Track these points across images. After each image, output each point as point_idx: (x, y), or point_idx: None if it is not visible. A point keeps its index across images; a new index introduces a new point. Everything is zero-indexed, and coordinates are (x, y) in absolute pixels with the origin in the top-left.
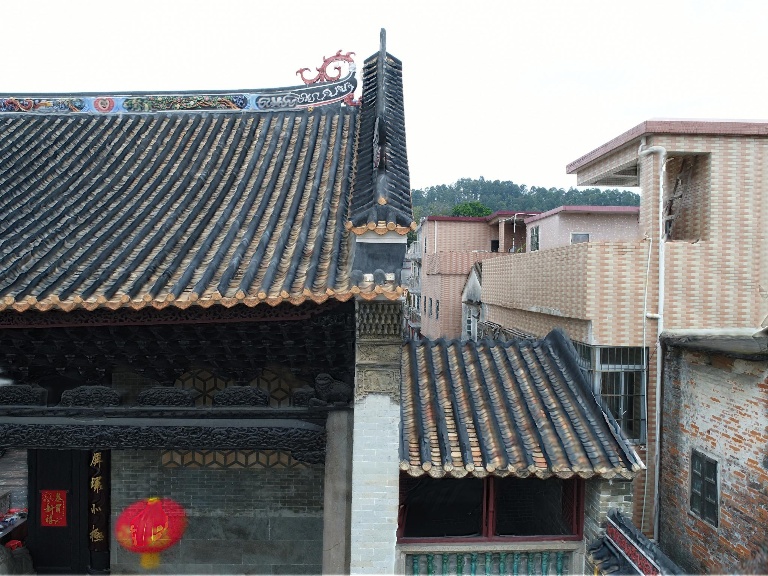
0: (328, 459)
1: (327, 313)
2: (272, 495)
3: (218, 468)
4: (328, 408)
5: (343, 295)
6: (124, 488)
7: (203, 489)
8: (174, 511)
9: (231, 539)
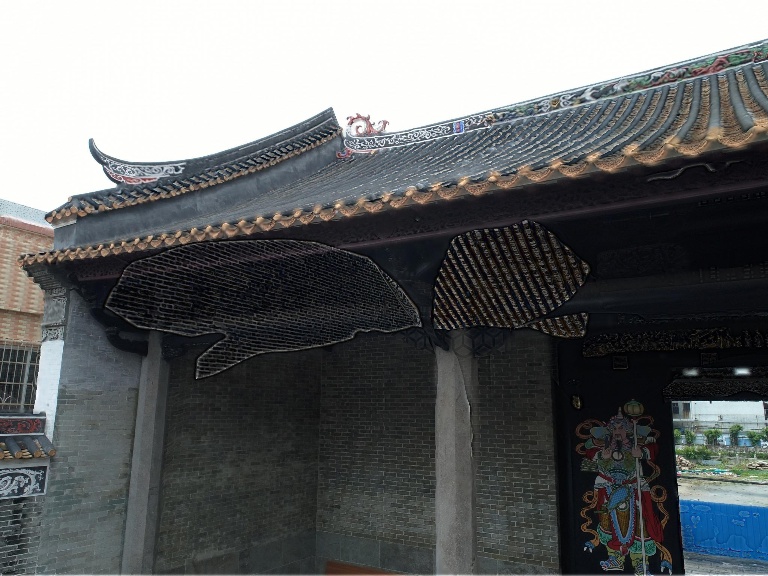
0: None
1: None
2: None
3: None
4: None
5: None
6: None
7: None
8: None
9: None
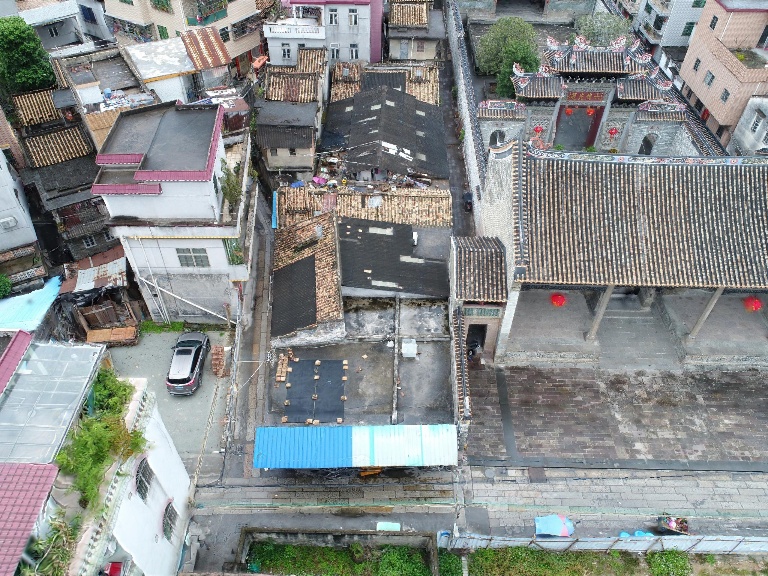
0: None
1: None
2: None
3: None
4: None
5: None
6: None
7: None
8: None
9: None
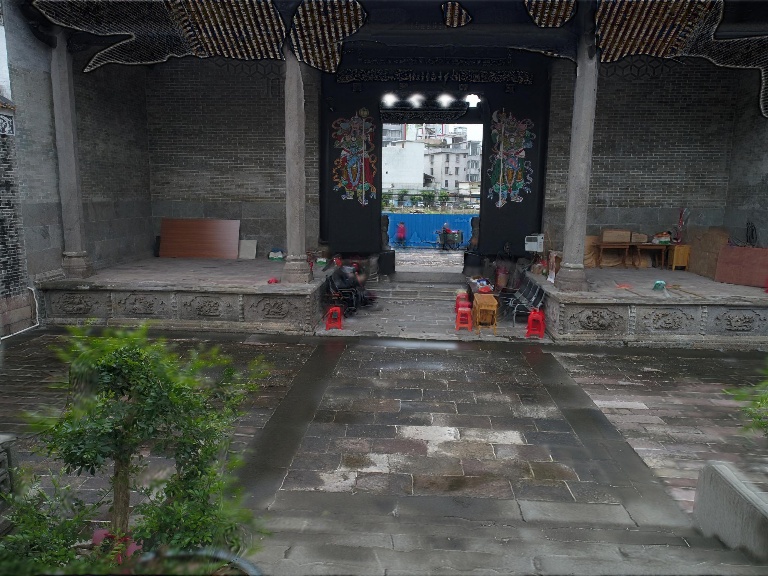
0: None
1: None
2: None
3: None
4: None
5: None
6: None
7: None
8: None
9: None
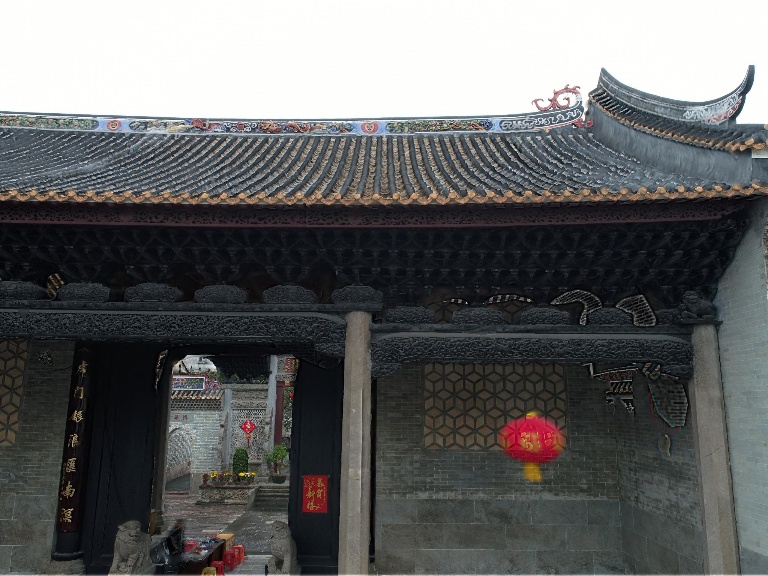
0: (698, 370)
1: (730, 217)
2: (532, 477)
3: (479, 450)
4: (698, 321)
5: (767, 189)
6: (388, 470)
7: (465, 471)
8: (437, 494)
9: (494, 523)
